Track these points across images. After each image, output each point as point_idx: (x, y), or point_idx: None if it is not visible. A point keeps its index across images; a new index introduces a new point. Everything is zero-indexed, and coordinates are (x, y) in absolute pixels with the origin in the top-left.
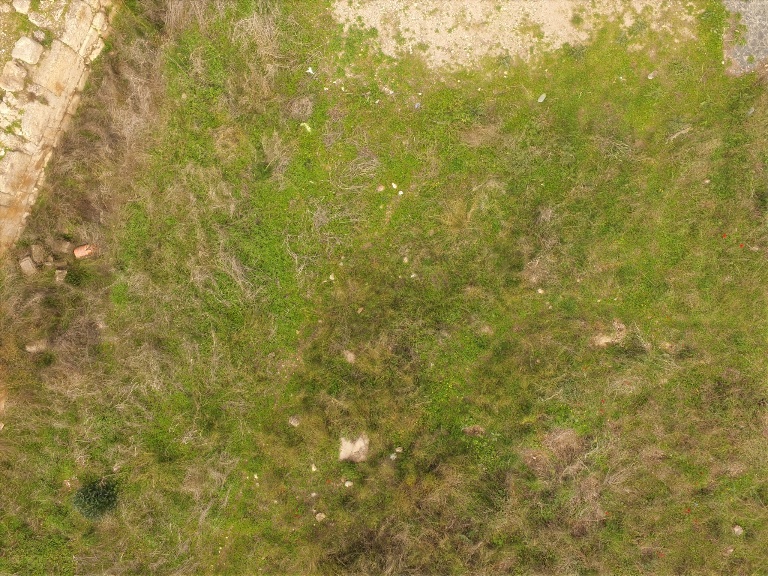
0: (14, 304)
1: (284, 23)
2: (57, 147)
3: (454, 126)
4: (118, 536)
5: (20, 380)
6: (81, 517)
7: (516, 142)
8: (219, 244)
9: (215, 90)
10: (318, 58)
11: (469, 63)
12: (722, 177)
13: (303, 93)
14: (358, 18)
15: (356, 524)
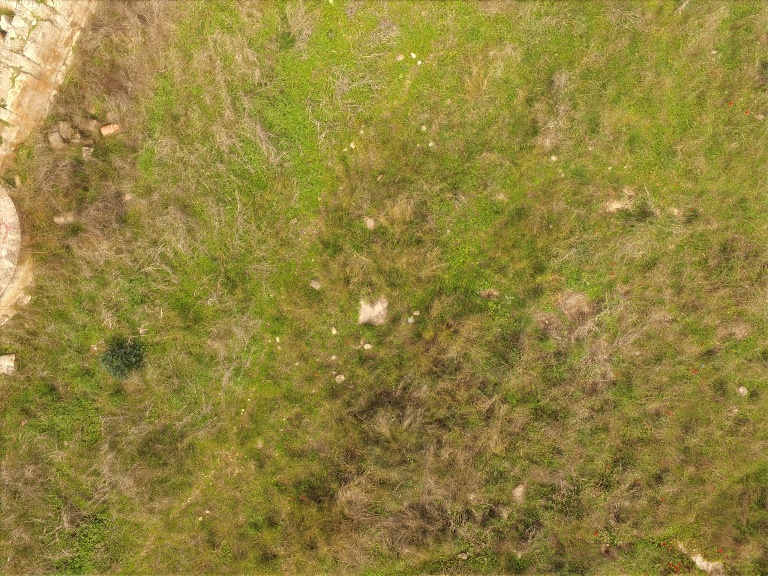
0: (44, 171)
1: None
2: (85, 26)
3: None
4: (143, 398)
5: (48, 250)
6: (108, 379)
7: (531, 12)
8: (244, 109)
9: None
10: None
11: None
12: (728, 48)
13: None
14: None
15: (375, 385)
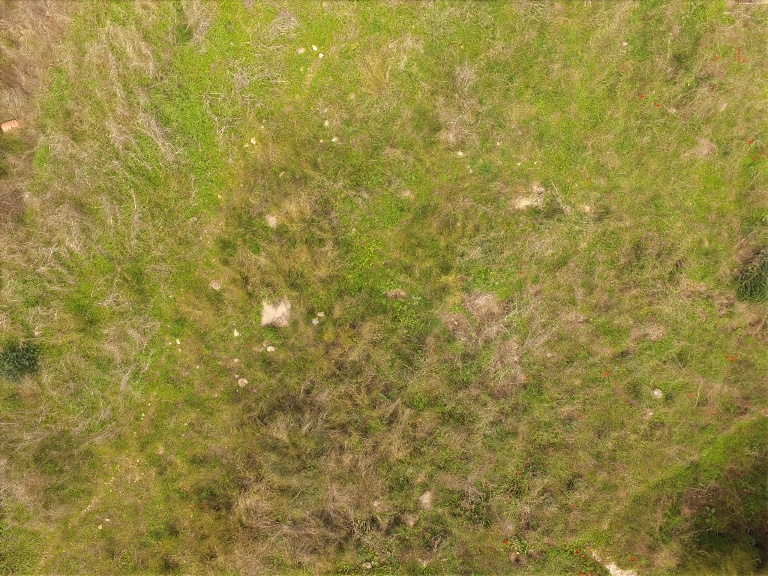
0: None
1: None
2: None
3: None
4: (40, 402)
5: None
6: (3, 383)
7: (434, 3)
8: (139, 104)
9: None
10: None
11: None
12: (640, 39)
13: None
14: None
15: (278, 389)
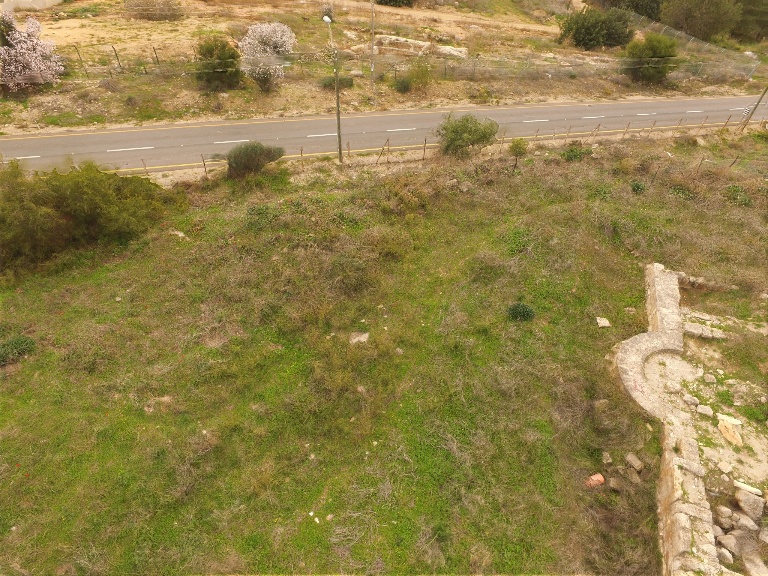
0: (625, 423)
1: None
2: None
3: None
4: None
5: None
6: None
7: None
8: None
9: None
10: None
11: None
12: None
13: None
14: None
15: None
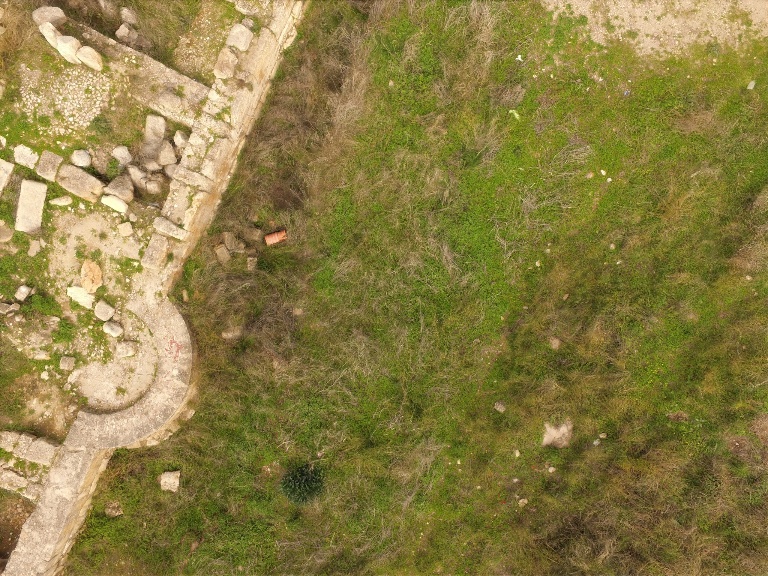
0: (219, 290)
1: (497, 11)
2: (252, 135)
3: (667, 113)
4: None
5: (216, 366)
6: (284, 502)
7: (728, 129)
8: (431, 230)
9: (425, 77)
10: (528, 46)
11: (678, 51)
12: None
13: (514, 80)
14: (568, 6)
15: (559, 510)
